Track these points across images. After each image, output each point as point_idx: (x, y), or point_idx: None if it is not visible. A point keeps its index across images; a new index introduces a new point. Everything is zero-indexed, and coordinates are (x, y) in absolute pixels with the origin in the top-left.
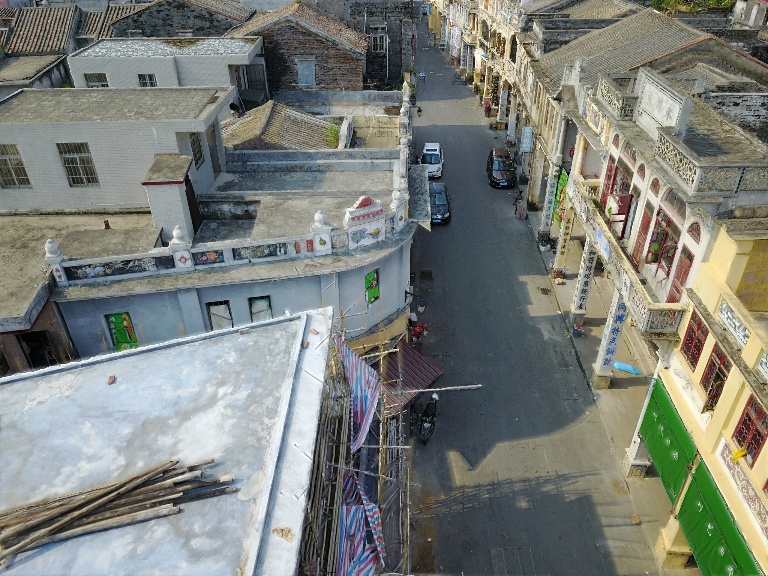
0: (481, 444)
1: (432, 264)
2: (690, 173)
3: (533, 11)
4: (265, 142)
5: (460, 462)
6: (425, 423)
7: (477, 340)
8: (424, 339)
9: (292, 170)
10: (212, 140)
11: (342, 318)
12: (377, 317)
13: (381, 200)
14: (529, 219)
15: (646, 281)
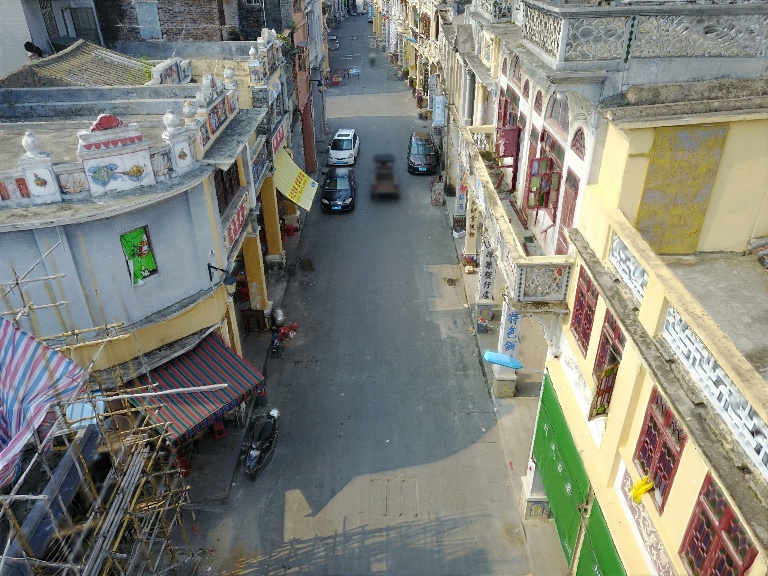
0: (331, 477)
1: (321, 255)
2: (555, 36)
3: None
4: (39, 76)
5: (296, 504)
6: (251, 450)
7: (356, 341)
8: (289, 342)
9: (78, 114)
10: None
11: (18, 284)
12: (159, 300)
13: (158, 132)
14: (446, 205)
15: (534, 238)
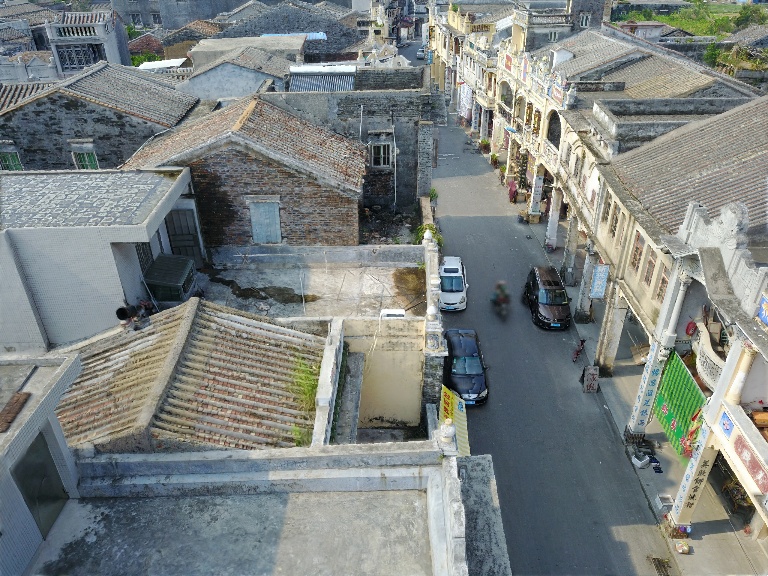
0: None
1: None
2: None
3: (573, 75)
4: (159, 439)
5: None
6: None
7: None
8: None
9: (217, 492)
10: (37, 455)
11: None
12: None
13: None
14: (603, 393)
15: None
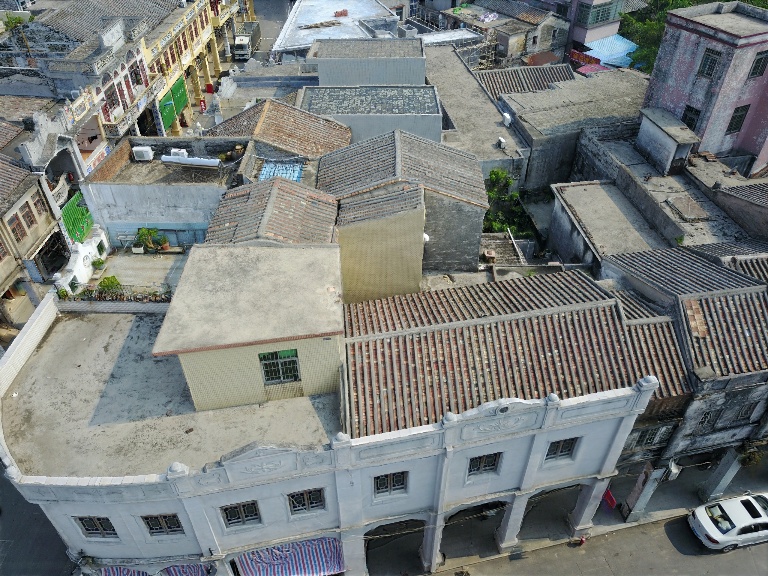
0: None
1: None
2: None
3: None
4: None
5: None
6: None
7: None
8: None
9: None
10: None
11: None
12: None
13: None
14: None
15: None
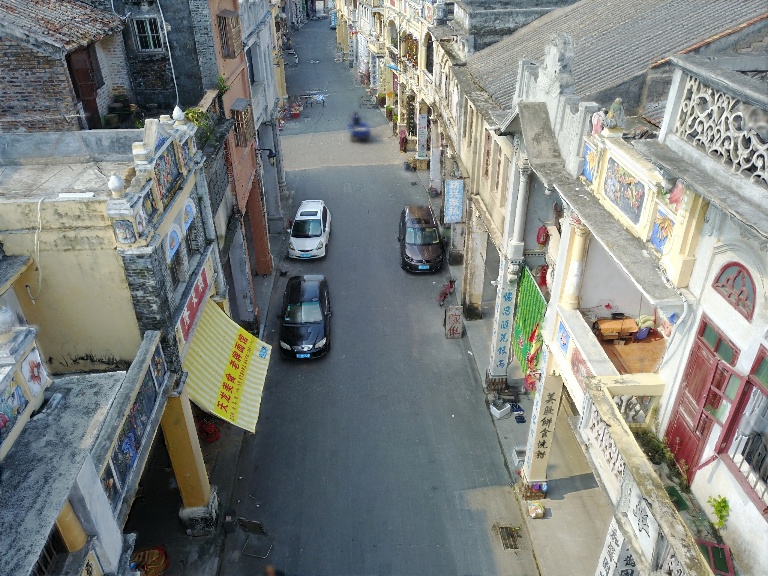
0: None
1: (281, 469)
2: None
3: None
4: None
5: None
6: None
7: None
8: None
9: None
10: None
11: None
12: None
13: None
14: (468, 337)
15: None
